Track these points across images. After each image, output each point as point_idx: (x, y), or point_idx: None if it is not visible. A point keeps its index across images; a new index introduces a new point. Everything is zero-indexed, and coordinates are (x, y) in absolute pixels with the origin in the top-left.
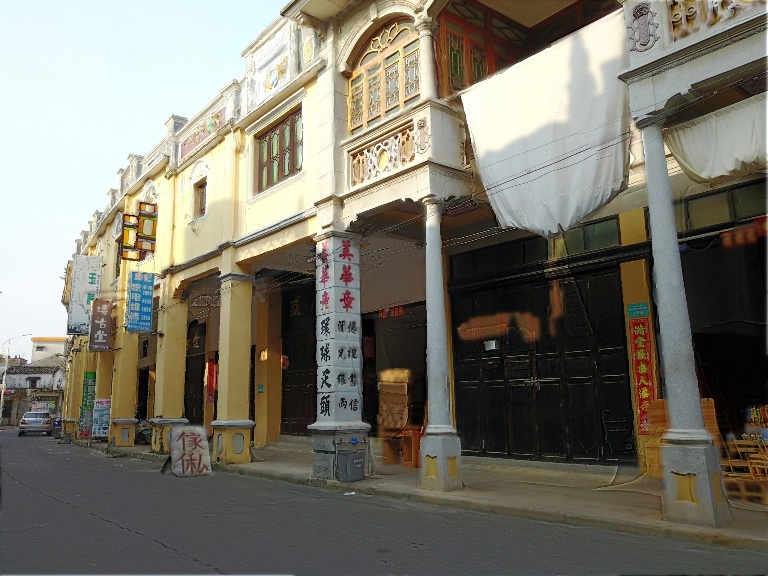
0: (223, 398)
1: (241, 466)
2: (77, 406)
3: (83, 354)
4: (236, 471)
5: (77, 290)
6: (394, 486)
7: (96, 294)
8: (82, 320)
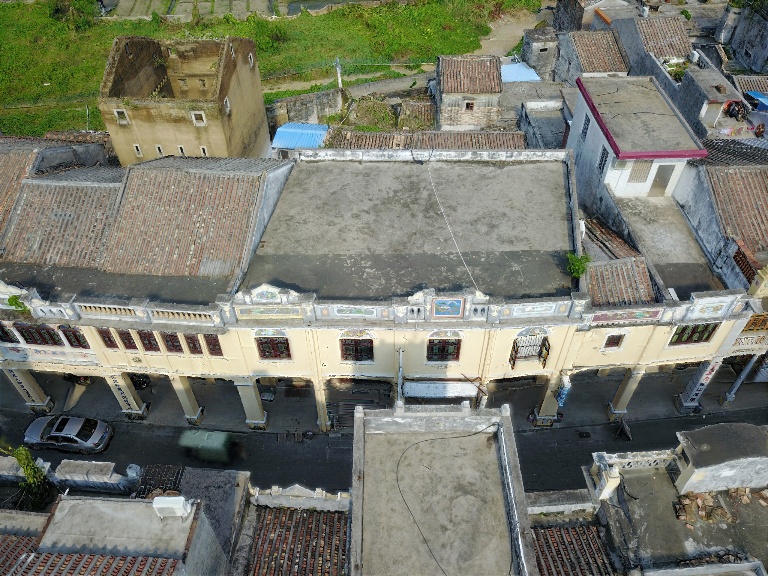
0: (624, 405)
1: (632, 418)
2: None
3: (320, 392)
4: (634, 421)
5: None
6: (714, 409)
7: None
8: None
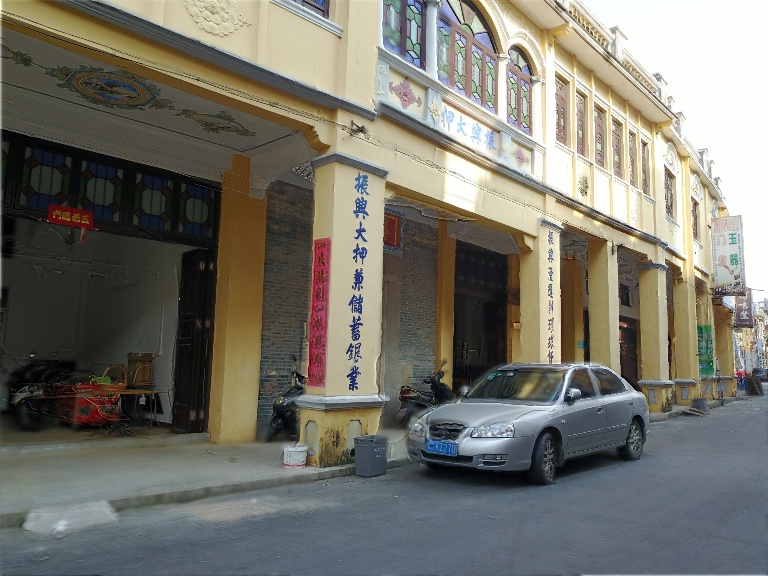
0: None
1: None
2: (698, 363)
3: (693, 296)
4: None
5: (737, 252)
6: None
7: (718, 256)
8: (731, 282)
